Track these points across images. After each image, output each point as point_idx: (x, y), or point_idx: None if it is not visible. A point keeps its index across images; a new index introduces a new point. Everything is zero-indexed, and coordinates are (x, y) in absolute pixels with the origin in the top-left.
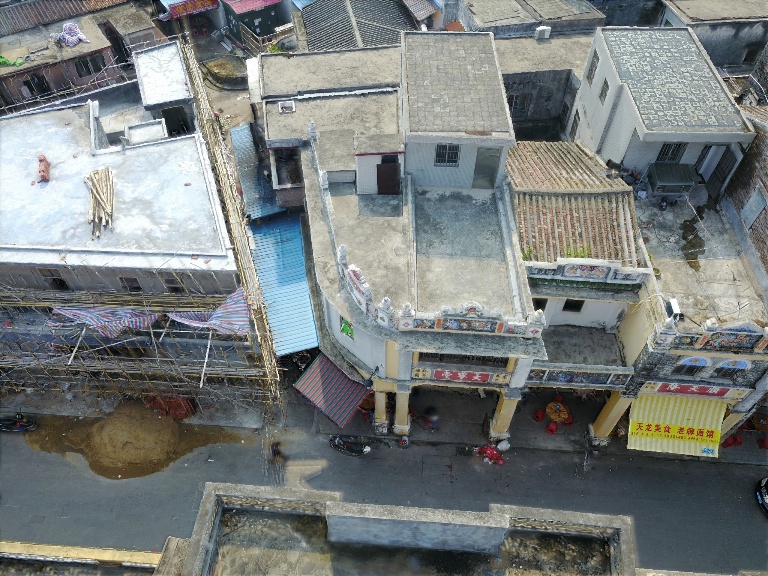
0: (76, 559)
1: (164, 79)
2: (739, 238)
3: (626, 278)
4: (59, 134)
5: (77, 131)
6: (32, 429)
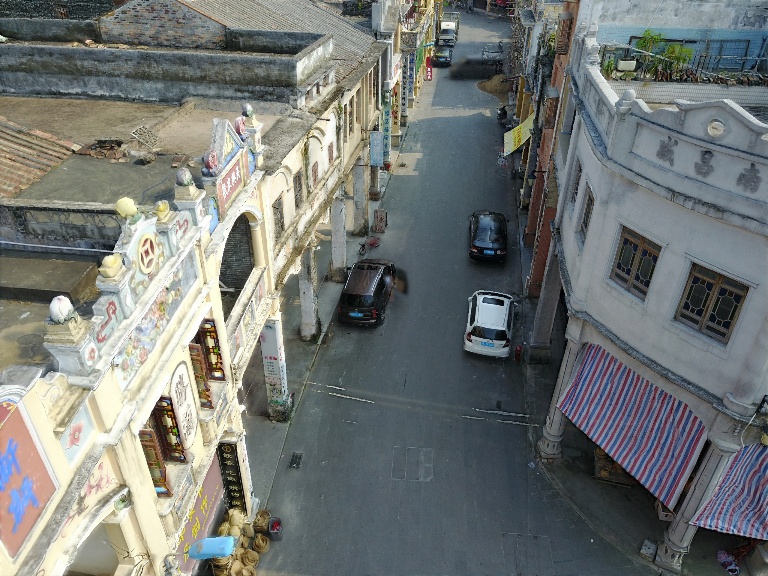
0: None
1: None
2: None
3: None
4: None
5: None
6: (498, 72)
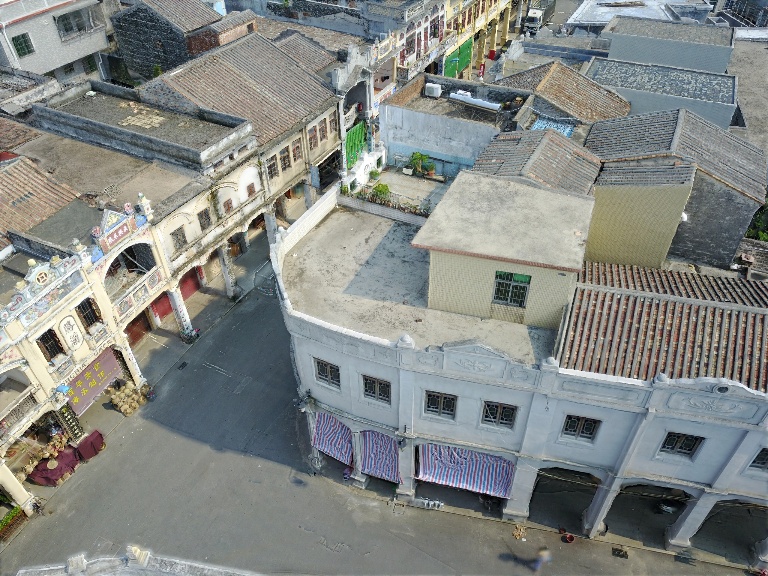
0: (463, 5)
1: (757, 34)
2: None
3: None
4: (680, 0)
5: (682, 3)
6: None
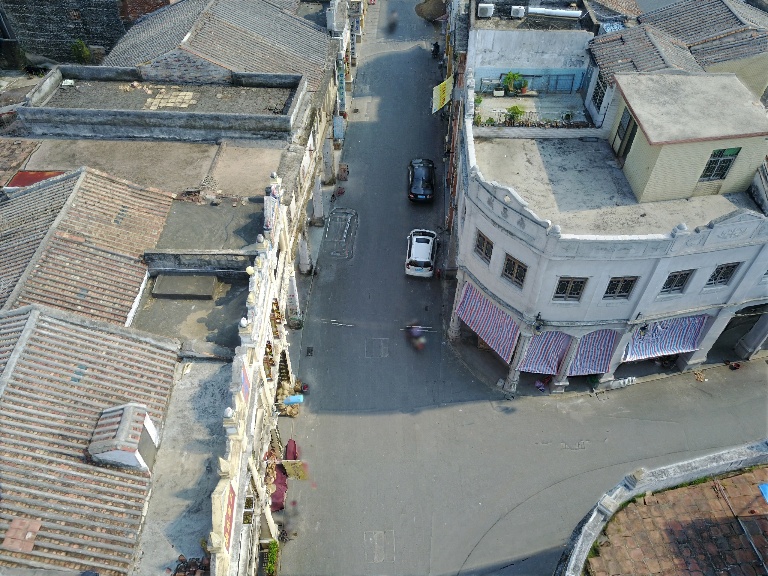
0: None
1: None
2: None
3: None
4: None
5: None
6: None
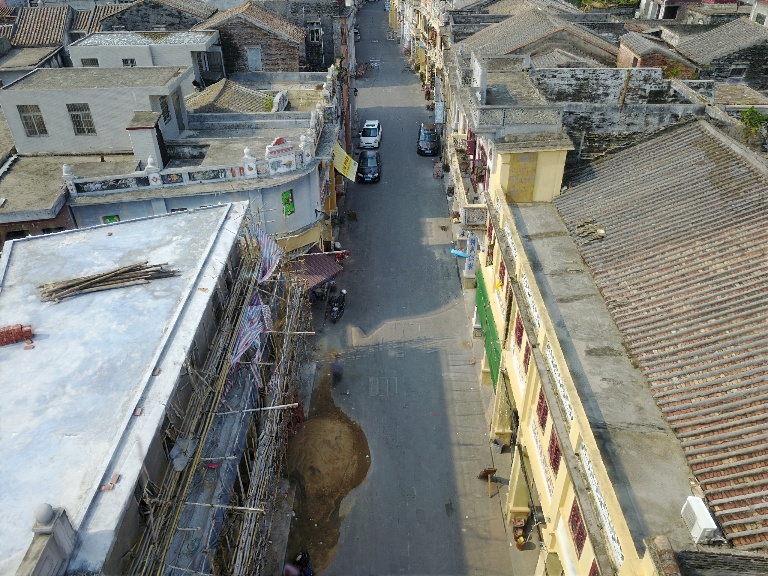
0: None
1: None
2: (261, 80)
3: (285, 100)
4: None
5: None
6: None
